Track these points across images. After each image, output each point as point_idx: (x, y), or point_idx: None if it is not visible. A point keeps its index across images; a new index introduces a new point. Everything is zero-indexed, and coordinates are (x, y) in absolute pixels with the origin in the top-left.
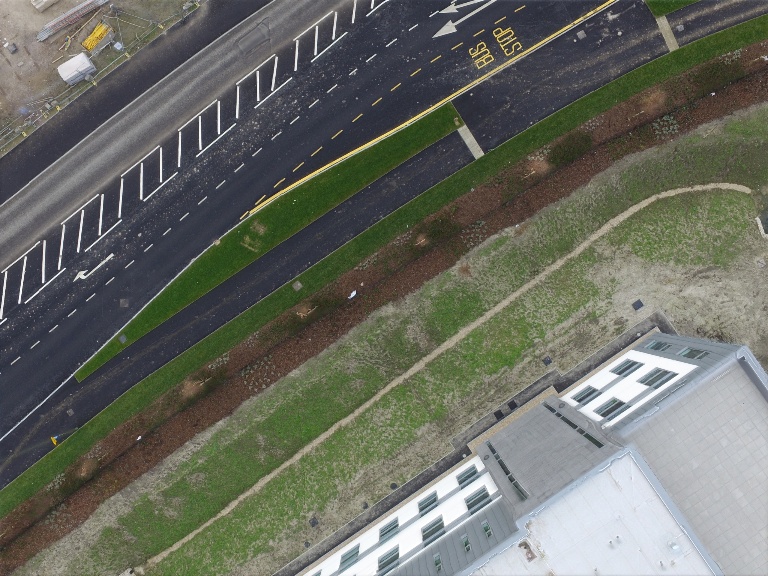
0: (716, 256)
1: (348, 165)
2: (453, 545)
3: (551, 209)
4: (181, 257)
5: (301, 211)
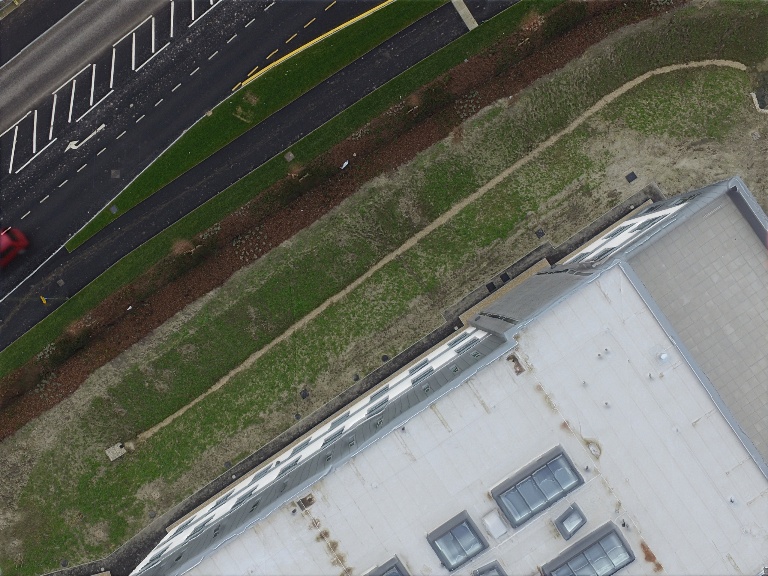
0: (710, 128)
1: (341, 36)
2: (442, 374)
3: (545, 80)
4: (173, 128)
5: (294, 81)
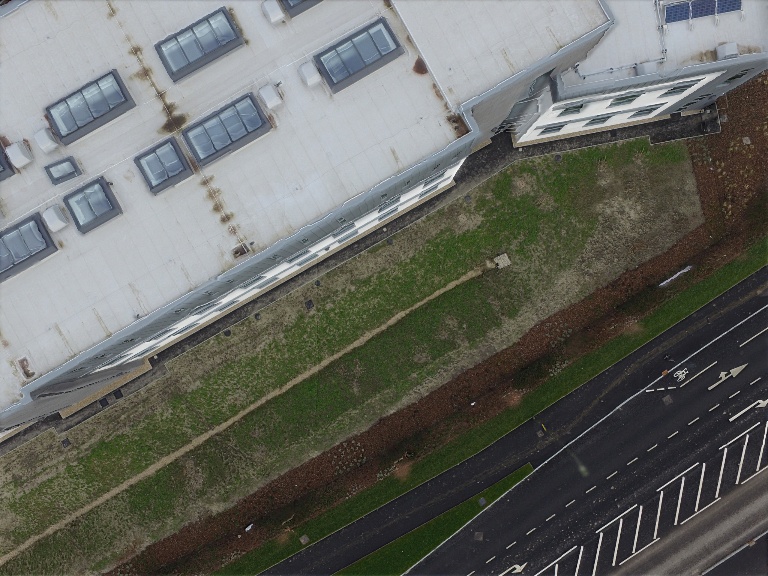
0: None
1: None
2: None
3: None
4: None
5: None
